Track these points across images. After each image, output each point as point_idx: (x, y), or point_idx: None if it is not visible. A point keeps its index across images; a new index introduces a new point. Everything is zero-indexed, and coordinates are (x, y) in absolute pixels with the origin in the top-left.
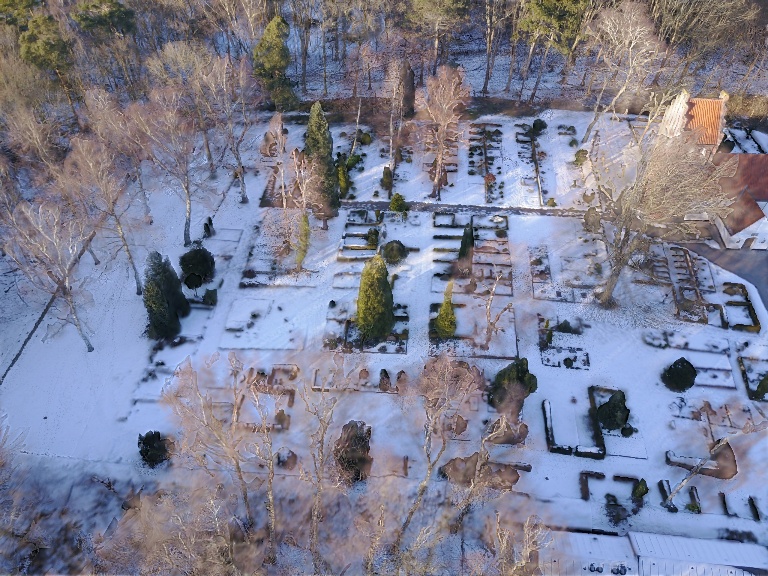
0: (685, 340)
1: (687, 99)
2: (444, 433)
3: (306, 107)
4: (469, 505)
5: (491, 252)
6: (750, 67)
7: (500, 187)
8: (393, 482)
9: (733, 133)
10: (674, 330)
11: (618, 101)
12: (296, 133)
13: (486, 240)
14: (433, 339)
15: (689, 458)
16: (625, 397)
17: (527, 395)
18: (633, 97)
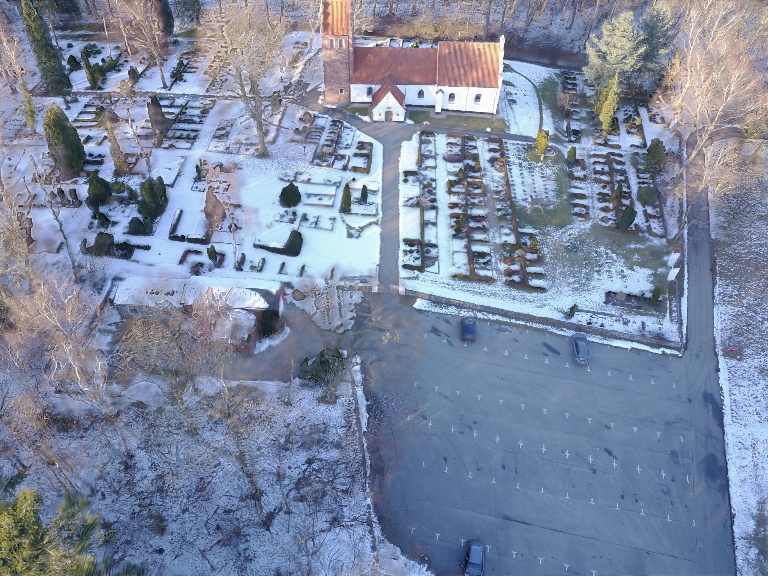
0: (309, 177)
1: None
2: (97, 229)
3: (93, 28)
4: (93, 267)
5: (189, 122)
6: (473, 1)
7: (222, 82)
8: (45, 256)
9: None
10: (305, 171)
11: None
12: (79, 47)
13: (190, 115)
14: (115, 175)
15: (267, 242)
16: (244, 210)
17: (162, 204)
18: (368, 23)
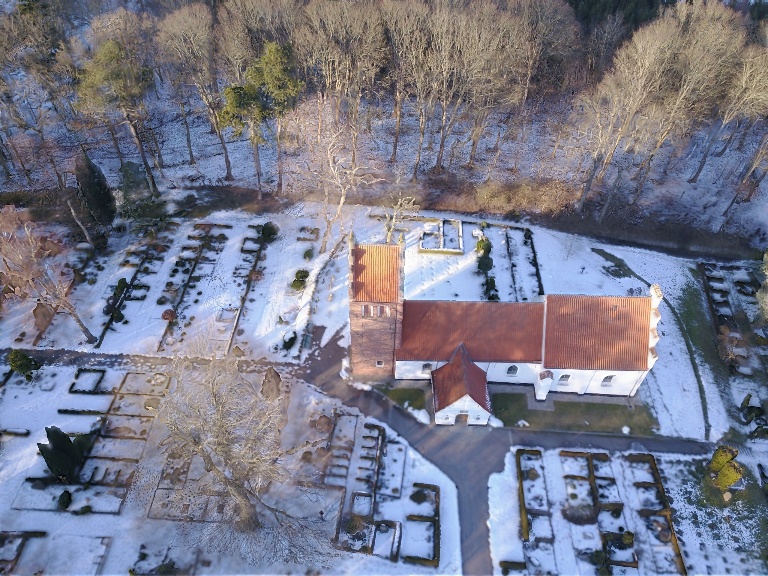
0: None
1: (352, 245)
2: None
3: None
4: None
5: (122, 437)
6: None
7: (185, 325)
8: None
9: (510, 236)
10: (323, 566)
11: (388, 190)
12: None
13: (126, 415)
14: None
15: None
16: None
17: None
18: (407, 184)
